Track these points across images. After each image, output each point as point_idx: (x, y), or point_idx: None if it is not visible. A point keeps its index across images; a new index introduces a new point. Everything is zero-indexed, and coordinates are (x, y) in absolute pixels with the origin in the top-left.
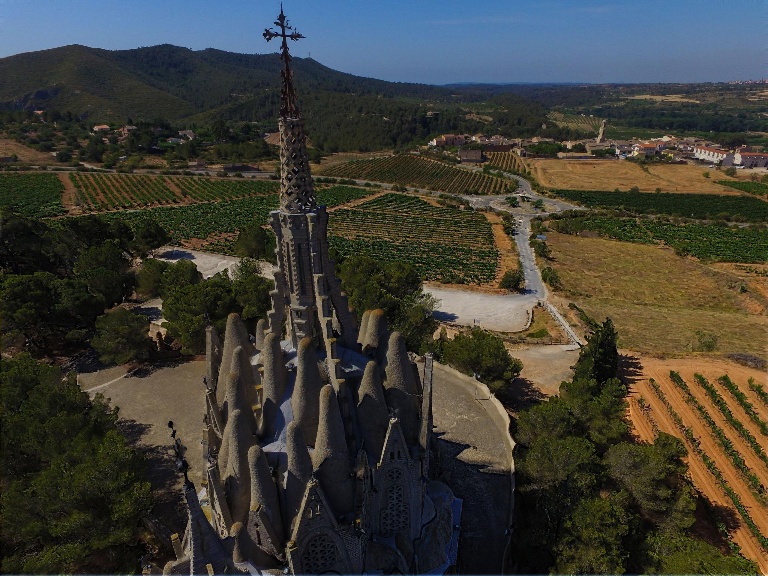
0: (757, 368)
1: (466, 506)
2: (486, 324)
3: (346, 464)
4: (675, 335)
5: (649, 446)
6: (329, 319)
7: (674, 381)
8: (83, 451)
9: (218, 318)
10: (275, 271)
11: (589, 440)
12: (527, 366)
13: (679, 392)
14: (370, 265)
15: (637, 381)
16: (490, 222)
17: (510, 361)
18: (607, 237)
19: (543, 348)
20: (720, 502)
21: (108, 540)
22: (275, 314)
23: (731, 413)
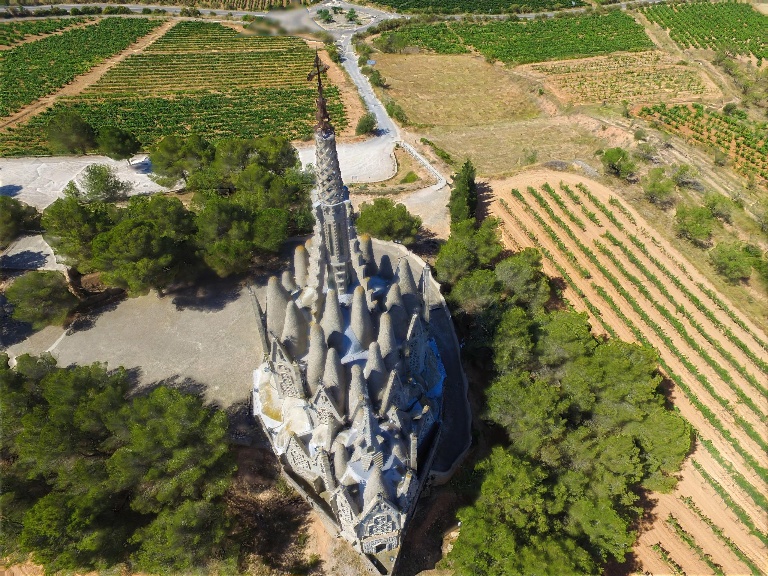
0: (563, 170)
1: None
2: (361, 177)
3: (398, 352)
4: (503, 150)
5: (518, 258)
6: (364, 267)
7: (515, 196)
8: (148, 411)
9: (158, 256)
10: (318, 245)
11: (476, 261)
12: (413, 213)
13: (519, 204)
14: (244, 147)
15: (491, 203)
16: (313, 48)
17: (413, 220)
18: (426, 50)
19: (420, 192)
20: (554, 276)
21: (214, 456)
22: (320, 273)
23: (553, 212)
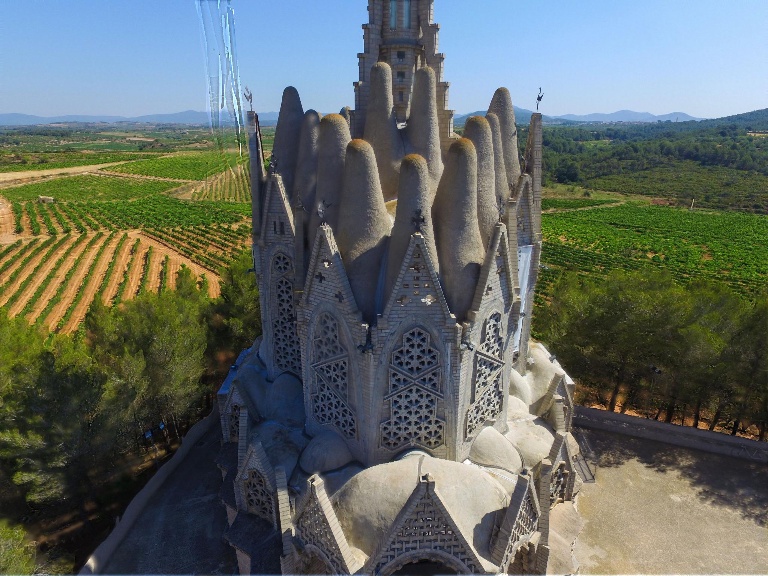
0: None
1: (198, 538)
2: None
3: None
4: None
5: None
6: None
7: None
8: None
9: None
10: None
11: None
12: None
13: None
14: None
15: None
16: None
17: None
18: None
19: None
20: None
21: None
22: None
23: None
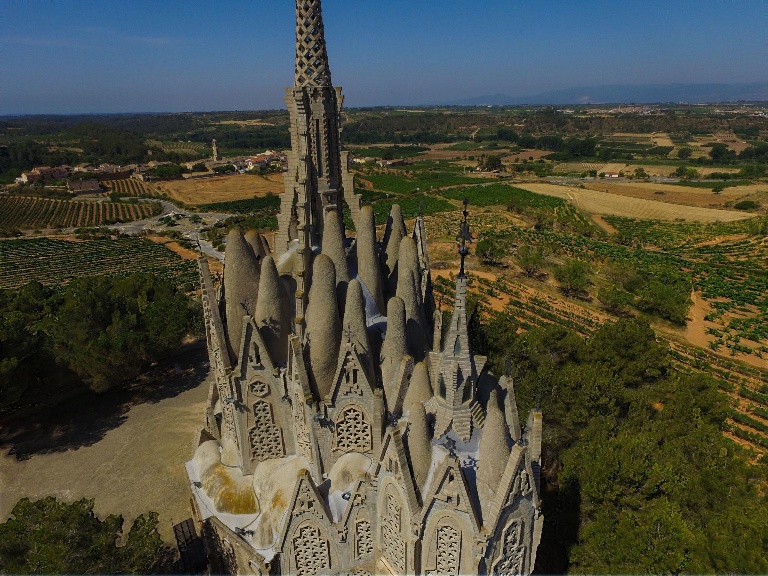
0: (446, 268)
1: None
2: None
3: None
4: None
5: None
6: None
7: None
8: None
9: None
10: (304, 155)
11: None
12: None
13: None
14: (105, 284)
15: None
16: (160, 242)
17: None
18: None
19: None
20: None
21: None
22: (307, 204)
23: None
